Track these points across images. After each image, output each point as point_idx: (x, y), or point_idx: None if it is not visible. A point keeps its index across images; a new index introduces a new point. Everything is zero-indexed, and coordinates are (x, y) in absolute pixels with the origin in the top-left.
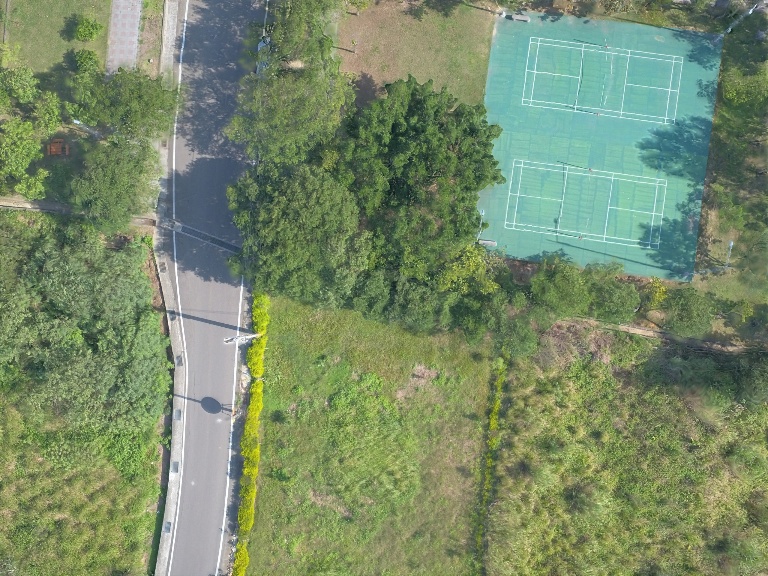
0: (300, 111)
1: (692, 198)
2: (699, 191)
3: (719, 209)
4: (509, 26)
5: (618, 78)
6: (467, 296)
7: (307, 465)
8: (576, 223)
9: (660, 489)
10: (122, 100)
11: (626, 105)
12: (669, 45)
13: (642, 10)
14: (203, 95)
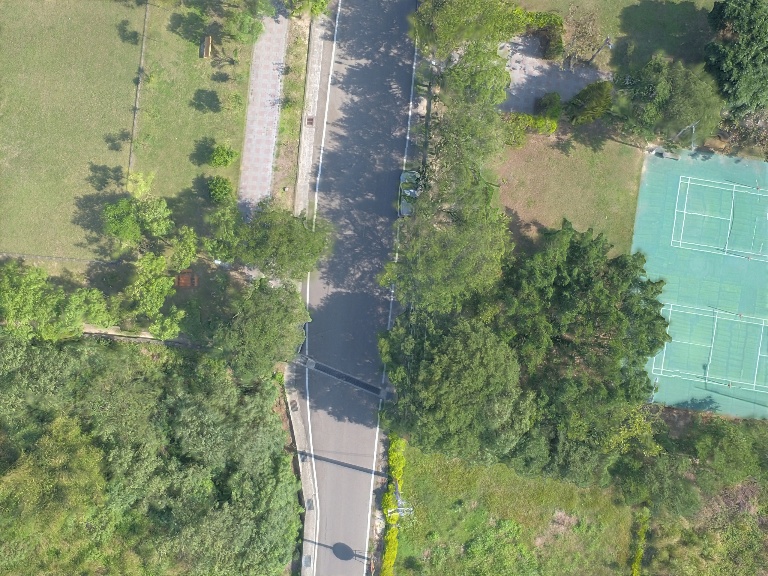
0: (463, 265)
1: None
2: None
3: None
4: (658, 164)
5: None
6: (626, 456)
7: None
8: (725, 370)
9: None
10: (268, 242)
11: None
12: None
13: None
14: (340, 226)
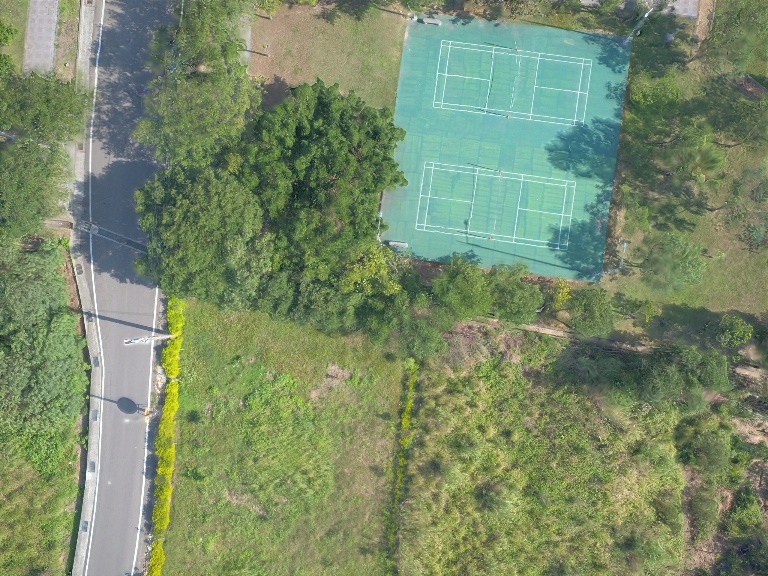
0: (203, 115)
1: (600, 199)
2: (607, 192)
3: (627, 210)
4: (421, 29)
5: (528, 81)
6: (371, 297)
7: (222, 464)
8: (486, 224)
9: (569, 487)
10: (32, 104)
11: (536, 107)
12: (578, 48)
13: (552, 13)
14: (119, 99)
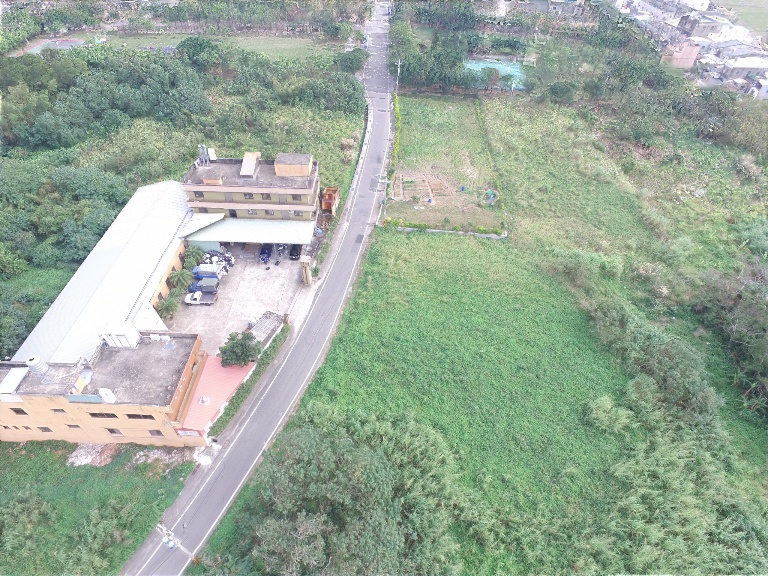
0: None
1: None
2: None
3: None
4: None
5: None
6: None
7: None
8: None
9: None
10: None
11: None
12: None
13: None
14: None
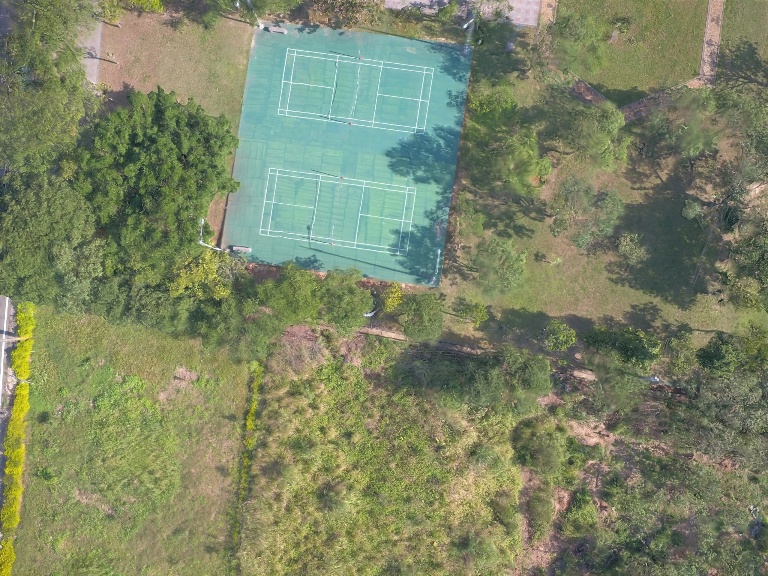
0: (35, 122)
1: (440, 206)
2: (447, 199)
3: None
4: (267, 38)
5: (371, 89)
6: (204, 301)
7: (72, 465)
8: (328, 230)
9: (407, 488)
10: None
11: (378, 115)
12: (420, 56)
13: (395, 22)
14: None
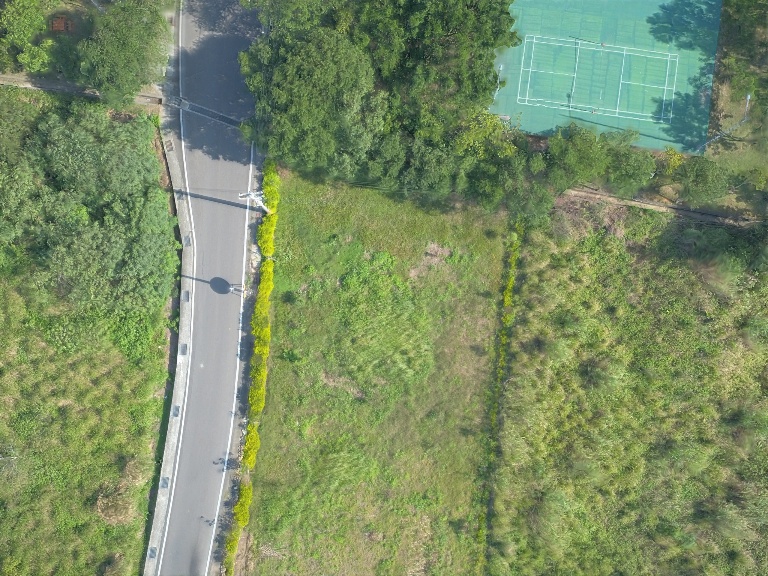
0: None
1: (703, 72)
2: (710, 66)
3: (730, 83)
4: None
5: None
6: (483, 161)
7: (319, 346)
8: (589, 98)
9: (675, 363)
10: None
11: None
12: None
13: None
14: None
